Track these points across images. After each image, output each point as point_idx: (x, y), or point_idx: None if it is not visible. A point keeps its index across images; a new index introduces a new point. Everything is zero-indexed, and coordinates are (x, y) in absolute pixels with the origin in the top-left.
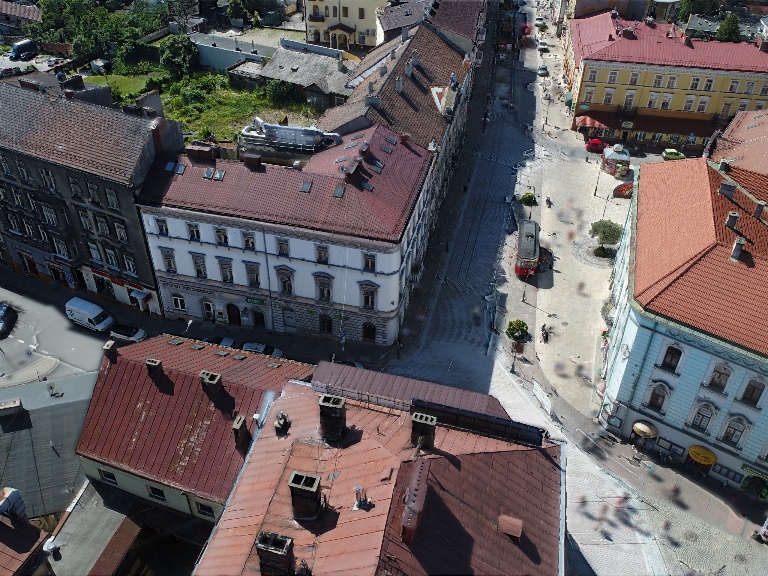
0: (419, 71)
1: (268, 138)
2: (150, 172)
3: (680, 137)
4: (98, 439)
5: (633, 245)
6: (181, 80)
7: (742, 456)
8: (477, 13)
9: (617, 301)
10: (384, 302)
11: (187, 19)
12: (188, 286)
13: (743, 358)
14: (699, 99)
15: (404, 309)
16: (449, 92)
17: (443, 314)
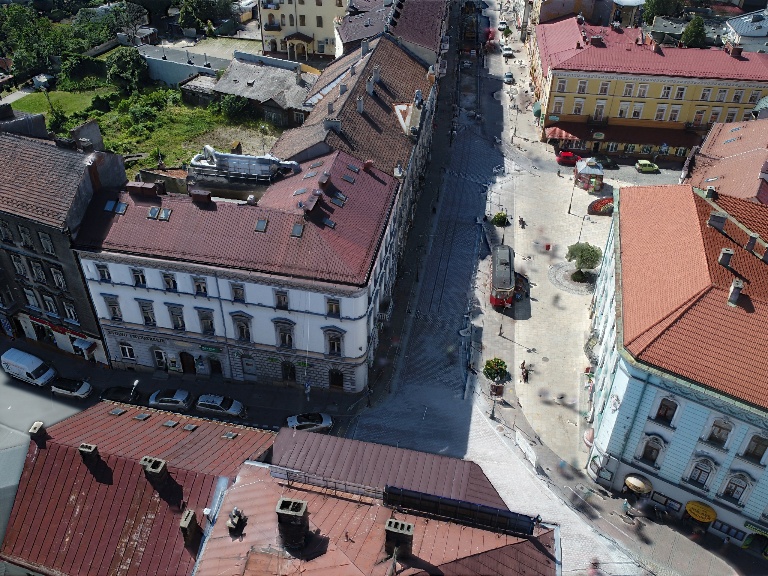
0: (381, 88)
1: (220, 168)
2: (88, 212)
3: (653, 147)
4: (25, 540)
5: (618, 283)
6: (130, 96)
7: (744, 513)
8: (440, 22)
9: (601, 337)
10: (351, 348)
11: (136, 30)
12: (136, 334)
13: (745, 413)
14: (671, 108)
15: (373, 349)
16: (414, 110)
17: (415, 353)
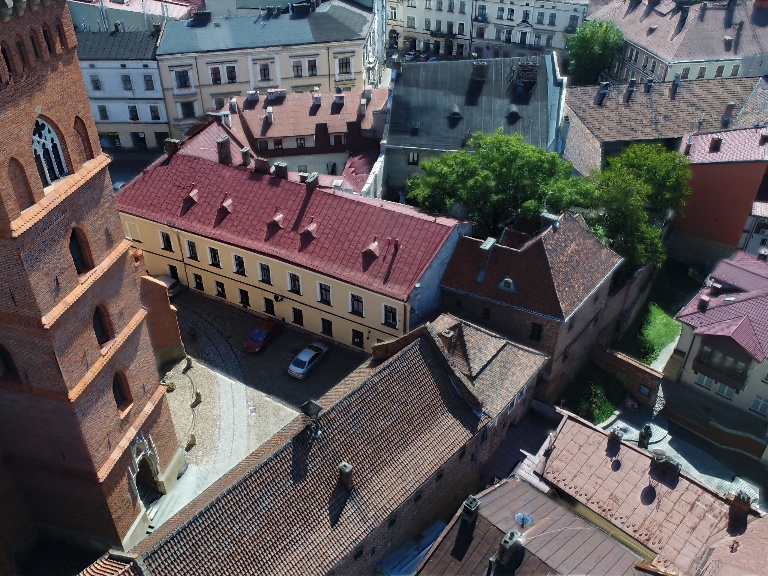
0: None
1: None
2: None
3: None
4: None
5: None
6: None
7: None
8: None
9: None
10: None
11: None
12: None
13: None
14: None
15: None
16: None
17: None
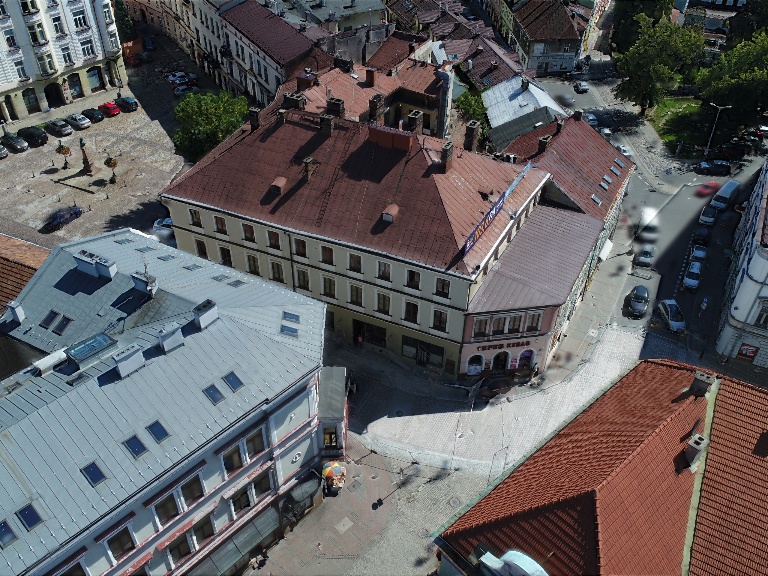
0: None
1: None
2: None
3: None
4: None
5: None
6: None
7: None
8: None
9: None
10: None
11: None
12: None
13: None
14: None
15: None
16: None
17: None
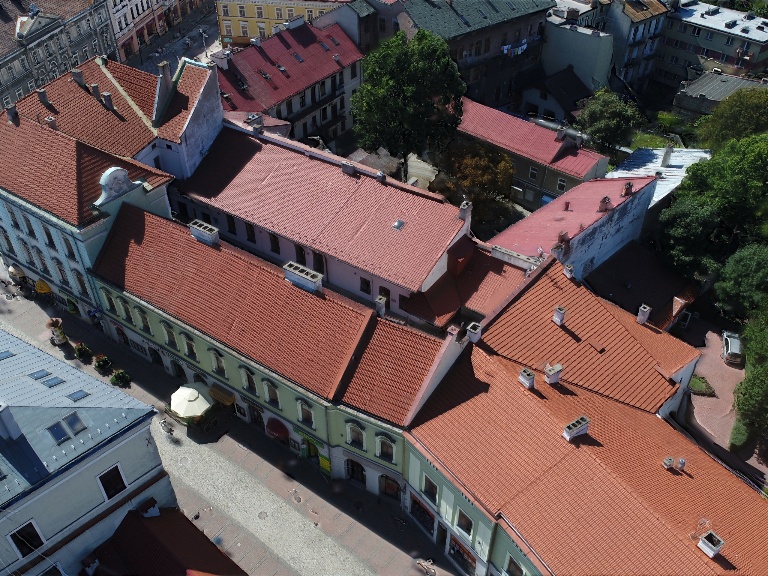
0: (13, 3)
1: None
2: None
3: None
4: None
5: None
6: None
7: (55, 282)
8: None
9: None
10: None
11: None
12: None
13: (8, 197)
14: None
15: None
16: (27, 20)
17: None
